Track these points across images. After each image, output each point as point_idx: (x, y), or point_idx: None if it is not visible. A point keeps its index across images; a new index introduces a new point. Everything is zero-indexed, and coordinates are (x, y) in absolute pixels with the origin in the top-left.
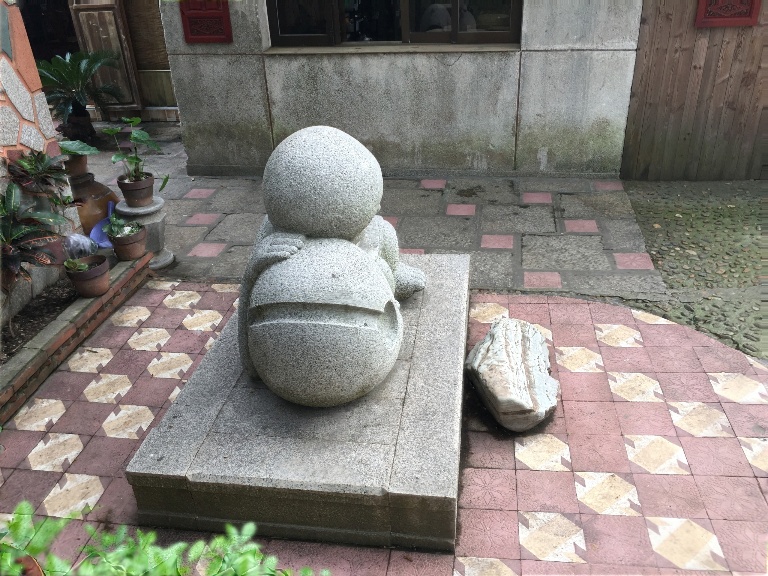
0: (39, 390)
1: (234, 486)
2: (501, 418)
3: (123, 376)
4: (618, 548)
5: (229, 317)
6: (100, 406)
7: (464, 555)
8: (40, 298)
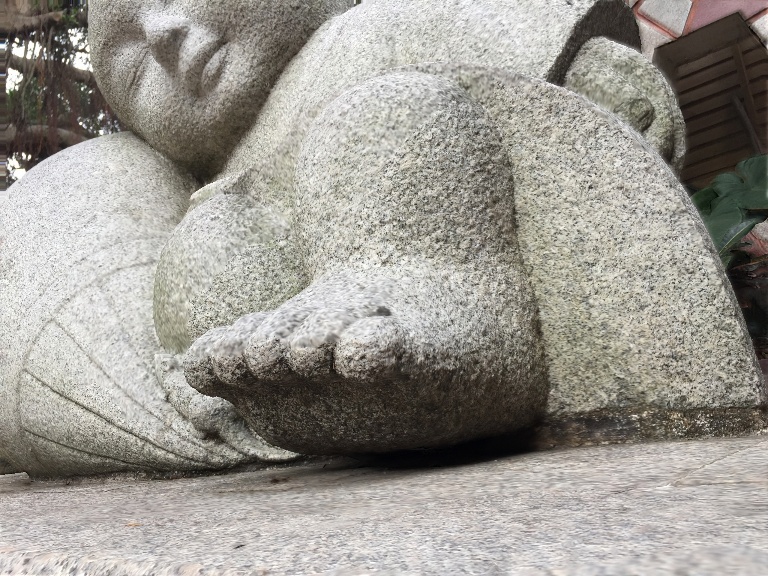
0: None
1: None
2: None
3: None
4: None
5: None
6: None
7: None
8: None
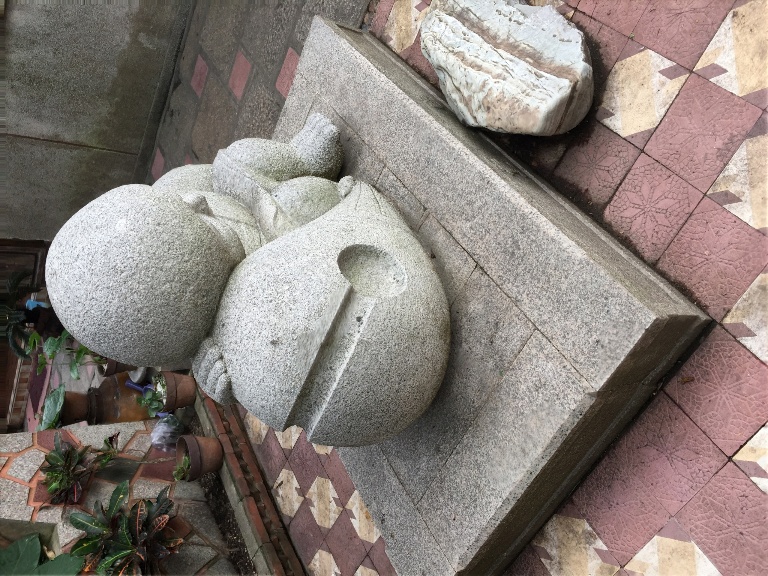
0: (301, 558)
1: (493, 534)
2: (562, 132)
3: (316, 480)
4: None
5: None
6: (339, 524)
7: (726, 312)
8: (209, 496)
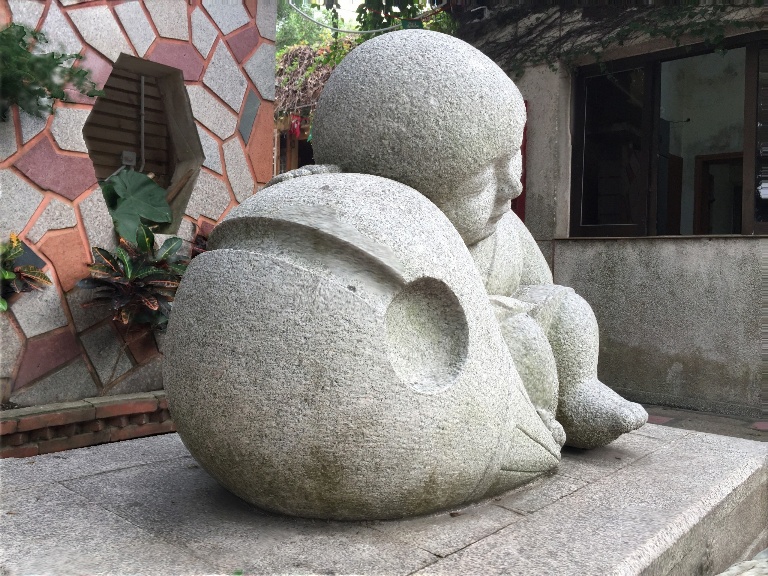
0: None
1: None
2: None
3: None
4: None
5: None
6: None
7: None
8: None
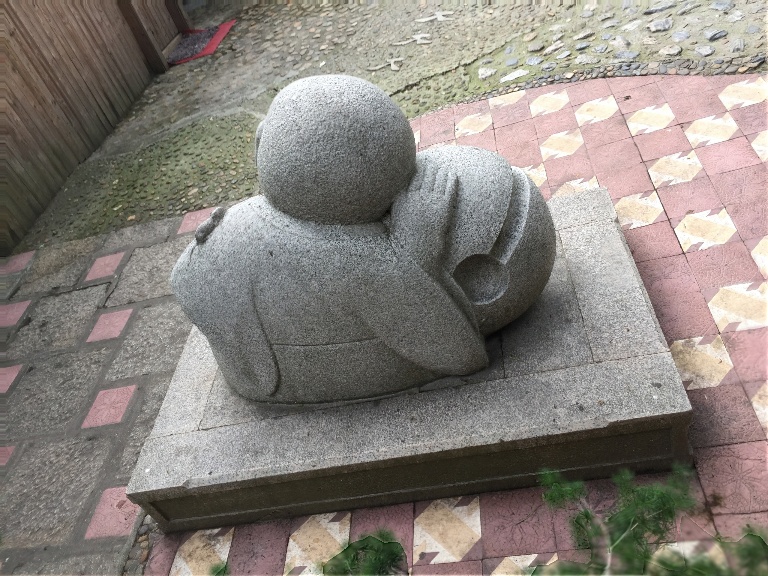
0: None
1: None
2: None
3: None
4: (577, 166)
5: (241, 574)
6: None
7: None
8: None
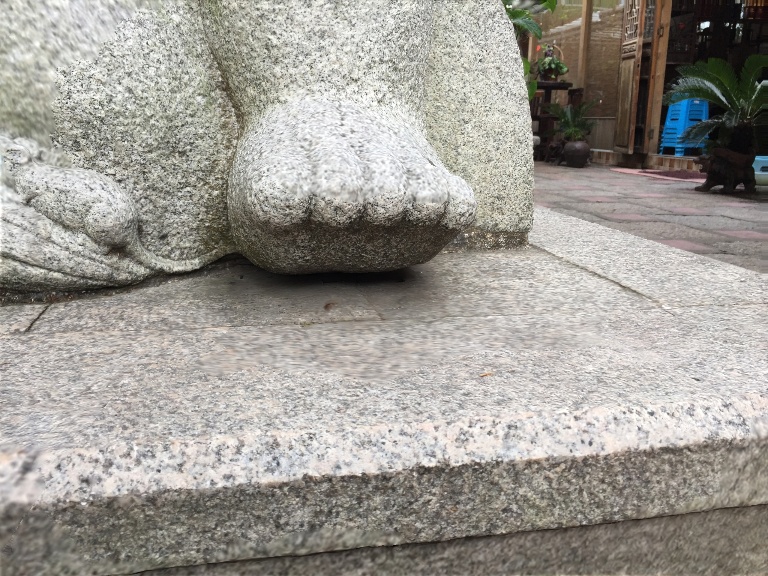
0: None
1: None
2: None
3: None
4: None
5: None
6: None
7: None
8: None
